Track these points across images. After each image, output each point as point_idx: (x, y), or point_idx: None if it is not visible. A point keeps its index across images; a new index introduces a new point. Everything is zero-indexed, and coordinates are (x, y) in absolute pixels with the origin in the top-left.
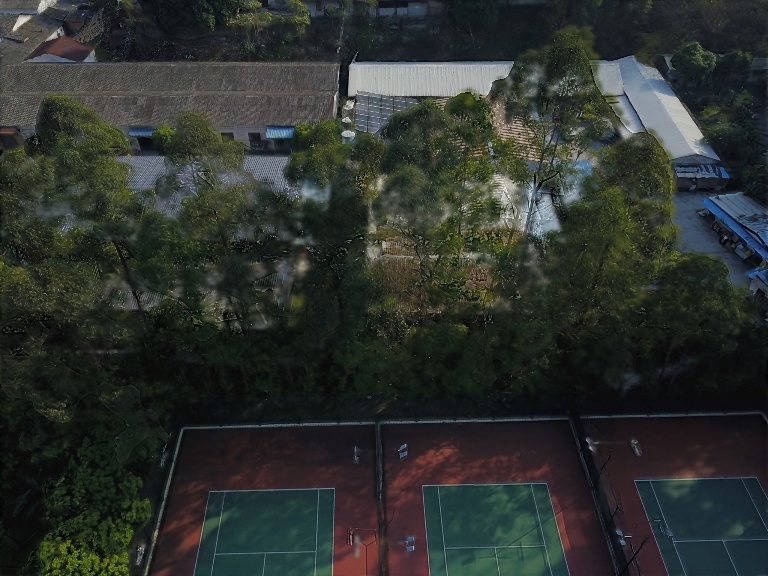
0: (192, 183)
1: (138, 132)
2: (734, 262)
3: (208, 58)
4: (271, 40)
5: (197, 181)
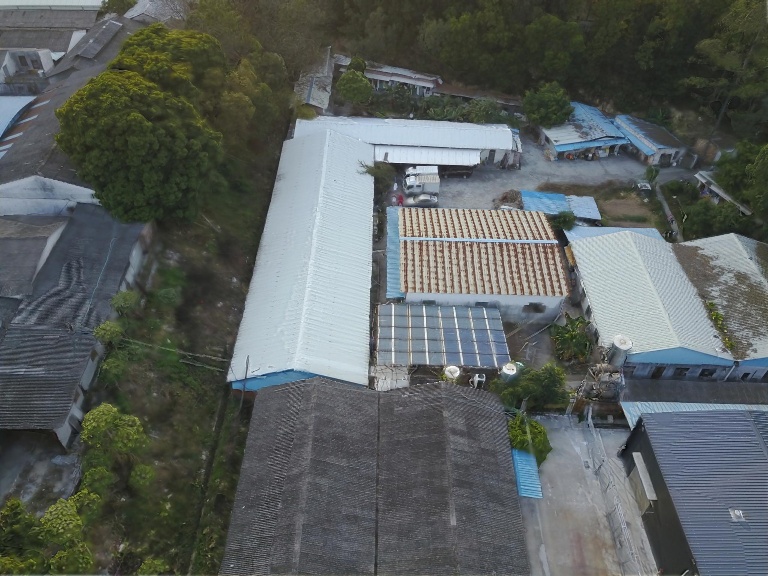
0: None
1: None
2: (611, 161)
3: None
4: (116, 523)
5: None
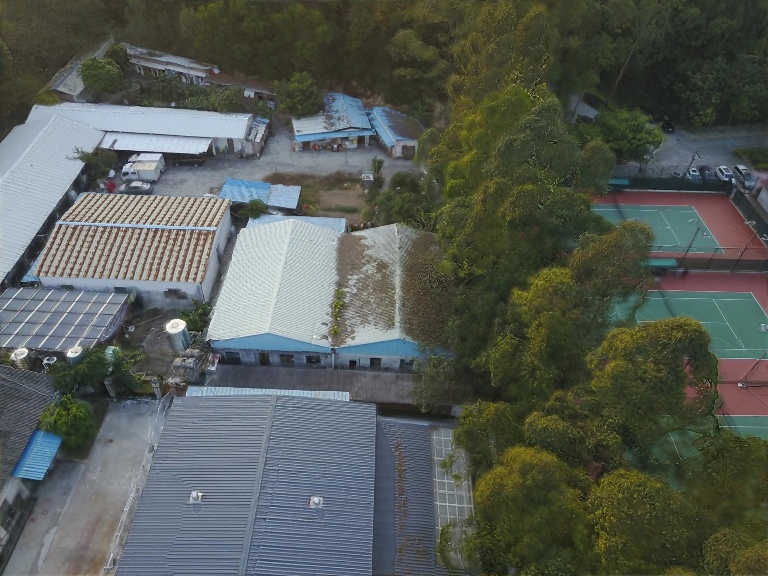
0: None
1: None
2: (358, 153)
3: None
4: None
5: None
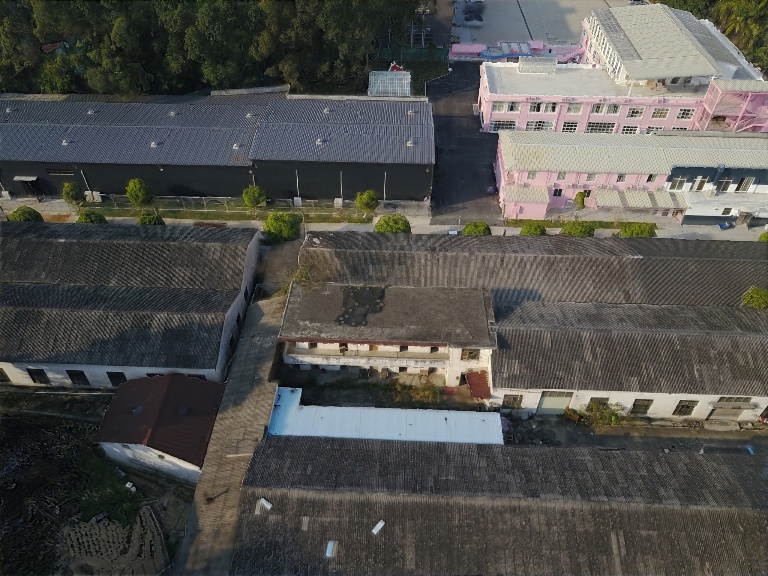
0: None
1: None
2: None
3: None
4: None
5: None
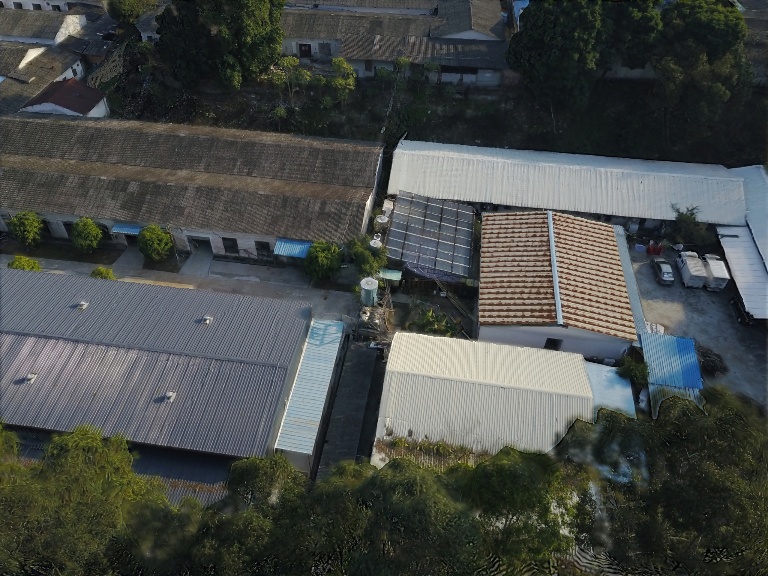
0: (24, 575)
1: (123, 228)
2: None
3: (232, 118)
4: (307, 103)
5: (32, 574)
